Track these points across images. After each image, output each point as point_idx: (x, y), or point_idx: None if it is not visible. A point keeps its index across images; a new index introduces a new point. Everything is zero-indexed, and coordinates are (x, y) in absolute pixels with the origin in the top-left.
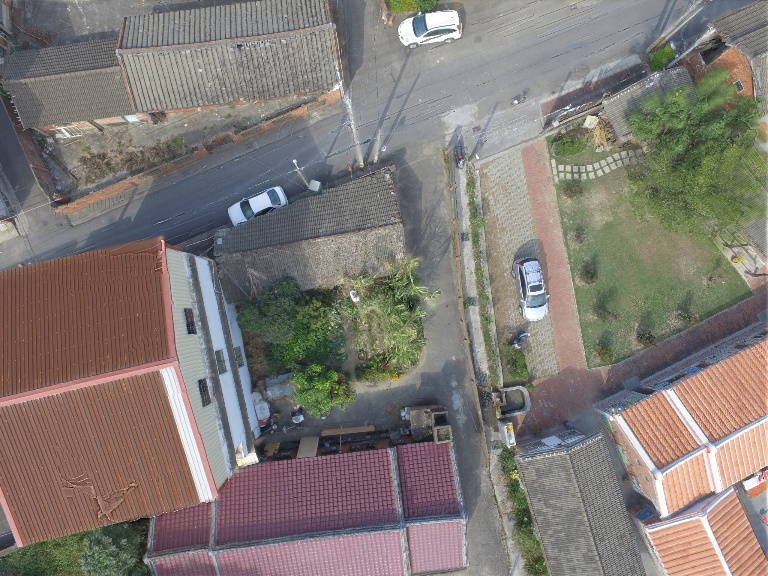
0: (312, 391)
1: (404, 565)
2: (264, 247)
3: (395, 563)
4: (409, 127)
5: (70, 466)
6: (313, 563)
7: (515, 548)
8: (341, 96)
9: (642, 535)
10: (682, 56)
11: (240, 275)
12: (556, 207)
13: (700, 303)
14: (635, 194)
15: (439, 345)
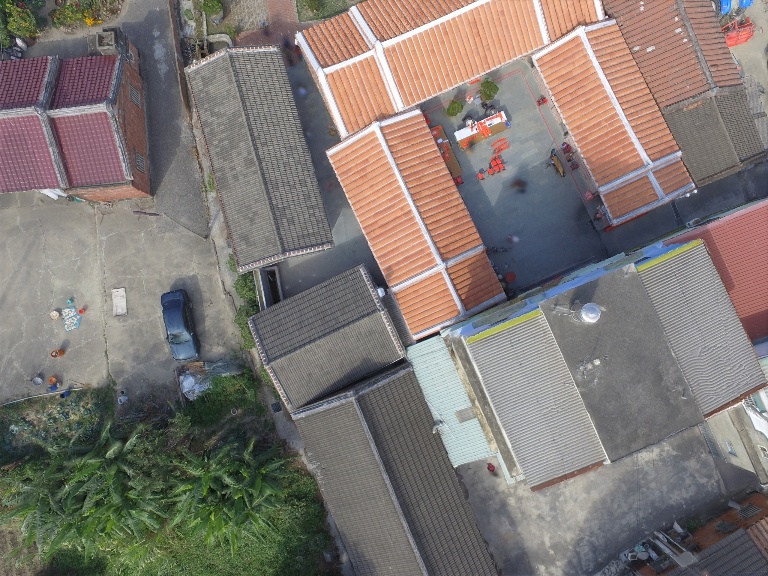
0: None
1: (54, 165)
2: None
3: (44, 163)
4: None
5: None
6: None
7: (216, 202)
8: None
9: None
10: None
11: None
12: None
13: None
14: None
15: None
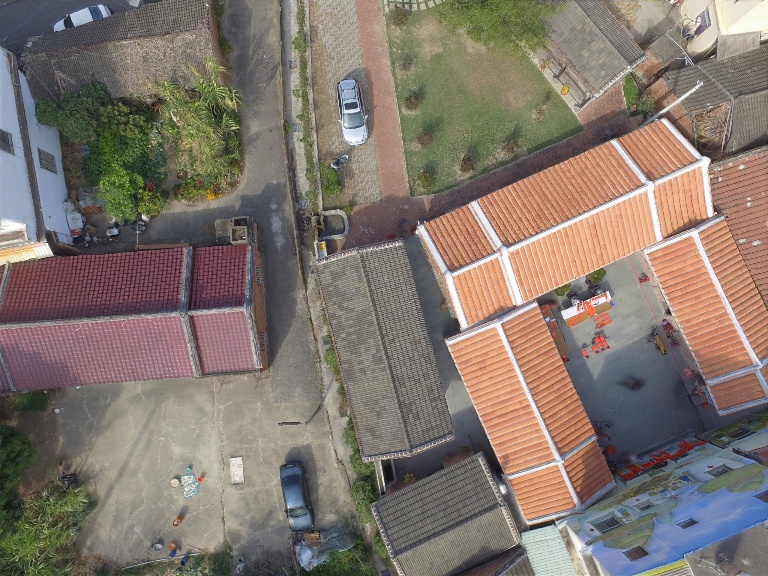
0: None
1: (190, 359)
2: (69, 47)
3: (181, 356)
4: None
5: None
6: (97, 351)
7: (329, 372)
8: None
9: None
10: None
11: (48, 78)
12: (385, 37)
13: (529, 136)
14: None
15: (260, 168)
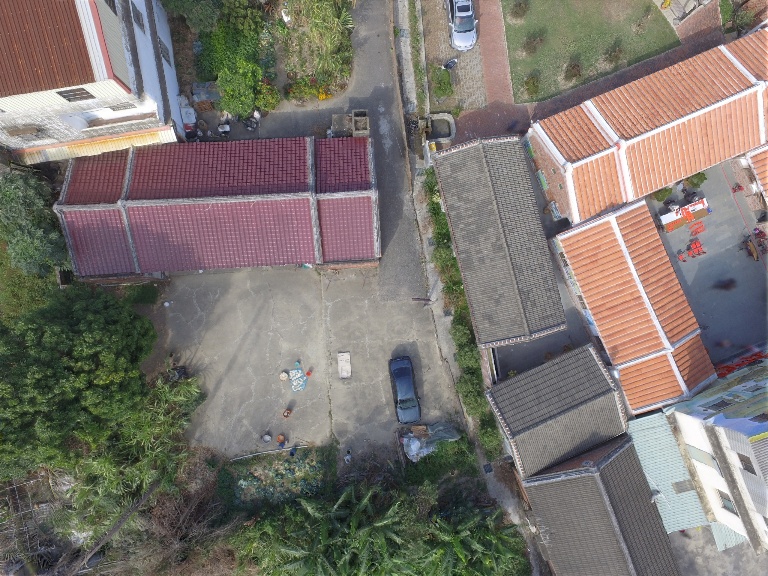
0: None
1: (315, 243)
2: None
3: (306, 241)
4: None
5: None
6: (224, 233)
7: (434, 272)
8: None
9: (558, 260)
10: None
11: None
12: None
13: (628, 49)
14: None
15: (368, 71)
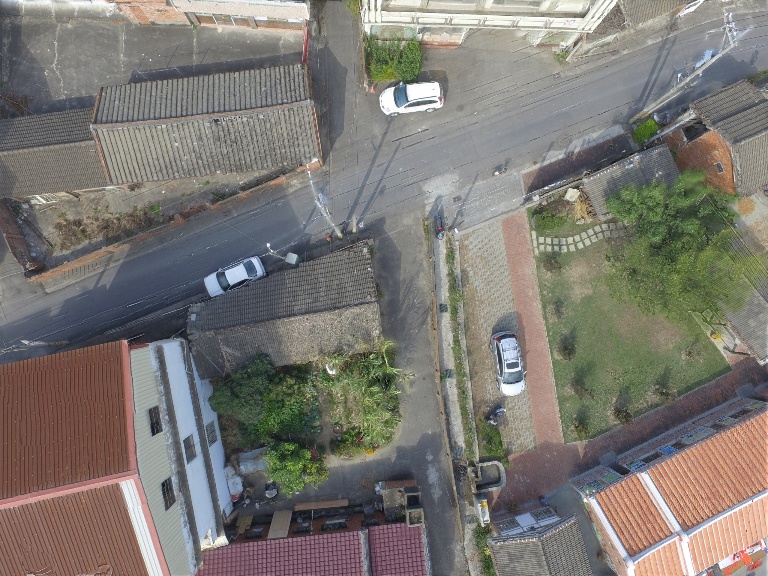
0: (284, 472)
1: None
2: (238, 325)
3: None
4: (389, 196)
5: (34, 559)
6: None
7: None
8: (321, 165)
9: None
10: (664, 133)
11: (213, 352)
12: (536, 279)
13: (678, 378)
14: (613, 276)
15: (415, 418)
